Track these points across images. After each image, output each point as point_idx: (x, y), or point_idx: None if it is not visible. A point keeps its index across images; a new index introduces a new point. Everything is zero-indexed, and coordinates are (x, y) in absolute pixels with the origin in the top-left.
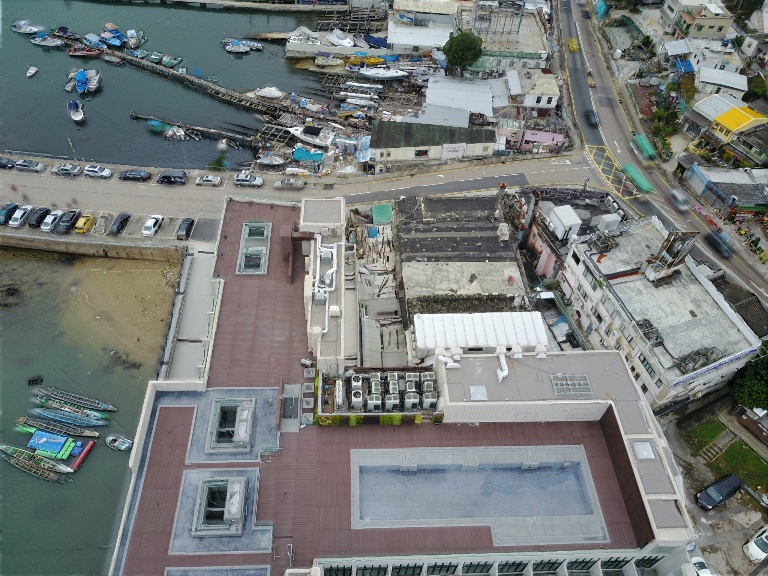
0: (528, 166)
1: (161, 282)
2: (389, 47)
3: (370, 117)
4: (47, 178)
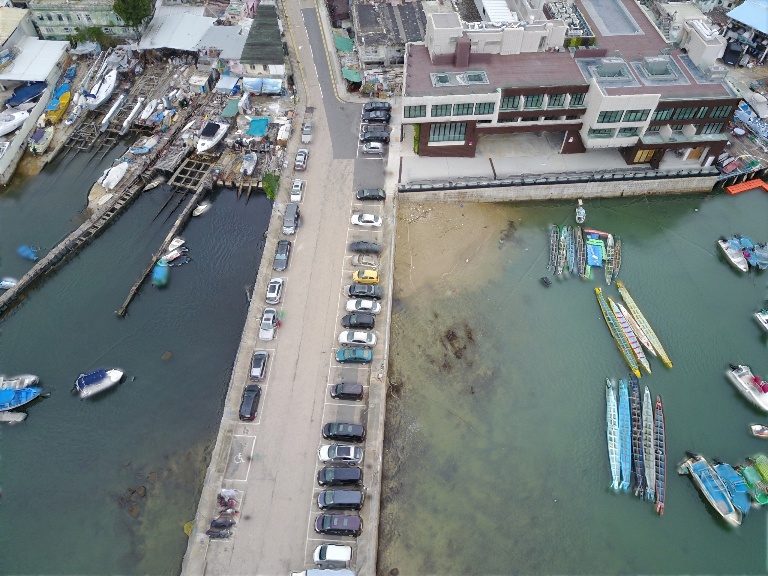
0: (292, 6)
1: (422, 221)
2: (45, 85)
3: (183, 100)
4: (280, 343)
